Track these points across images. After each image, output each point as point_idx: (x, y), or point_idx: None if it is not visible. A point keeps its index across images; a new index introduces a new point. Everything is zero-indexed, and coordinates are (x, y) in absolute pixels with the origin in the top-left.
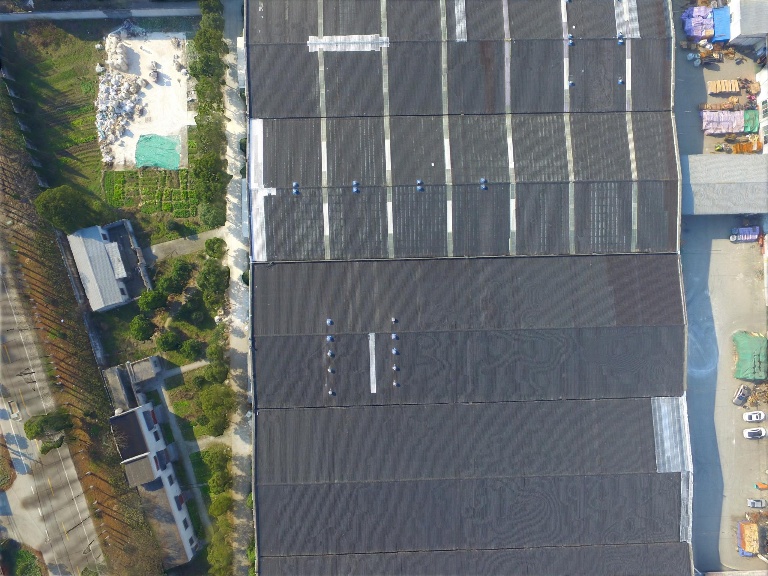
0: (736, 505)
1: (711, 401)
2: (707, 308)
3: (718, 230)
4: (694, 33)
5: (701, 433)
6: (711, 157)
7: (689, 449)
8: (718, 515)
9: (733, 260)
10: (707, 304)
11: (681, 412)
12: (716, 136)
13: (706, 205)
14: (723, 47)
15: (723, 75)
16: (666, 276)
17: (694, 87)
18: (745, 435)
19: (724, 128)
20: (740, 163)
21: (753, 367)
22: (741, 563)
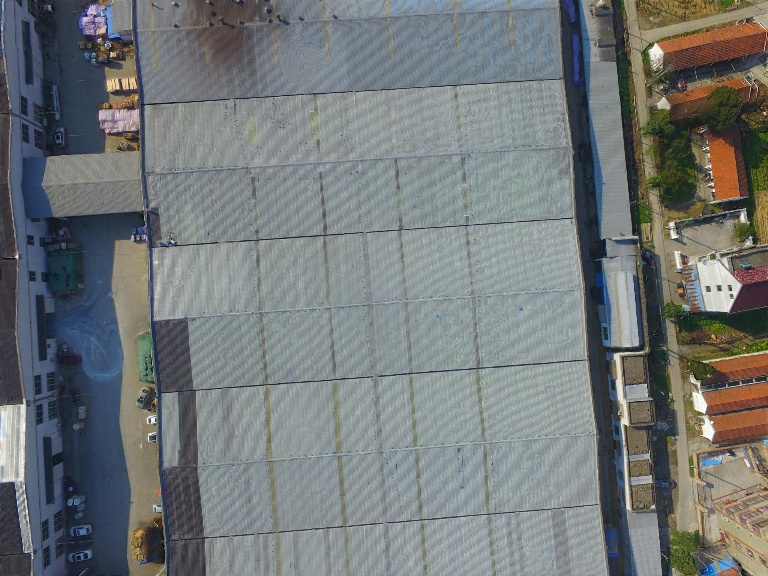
0: (144, 511)
1: (116, 406)
2: (111, 311)
3: (121, 231)
4: (86, 32)
5: (106, 439)
6: (70, 158)
7: (22, 458)
8: (125, 522)
9: (138, 261)
10: (111, 307)
11: (21, 420)
12: (118, 135)
13: (64, 207)
14: (124, 45)
15: (126, 73)
16: (3, 282)
17: (95, 87)
18: (148, 439)
19: (121, 127)
20: (99, 162)
21: (145, 369)
22: (150, 570)
